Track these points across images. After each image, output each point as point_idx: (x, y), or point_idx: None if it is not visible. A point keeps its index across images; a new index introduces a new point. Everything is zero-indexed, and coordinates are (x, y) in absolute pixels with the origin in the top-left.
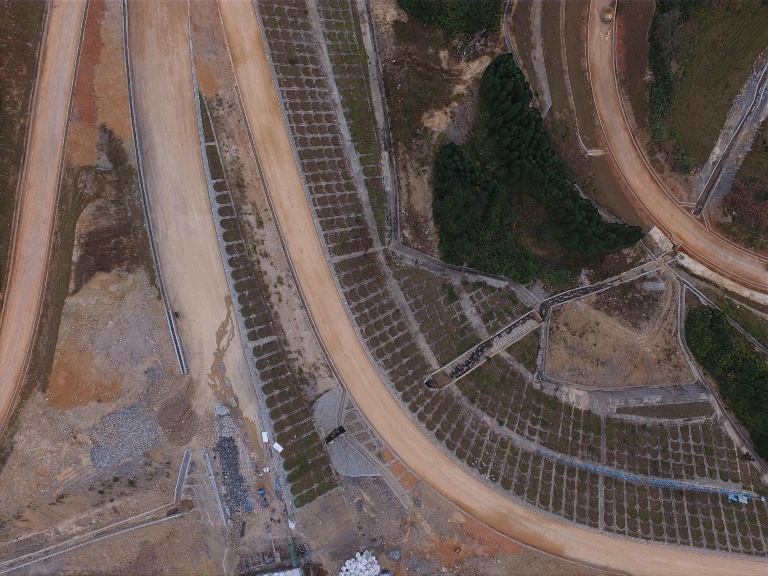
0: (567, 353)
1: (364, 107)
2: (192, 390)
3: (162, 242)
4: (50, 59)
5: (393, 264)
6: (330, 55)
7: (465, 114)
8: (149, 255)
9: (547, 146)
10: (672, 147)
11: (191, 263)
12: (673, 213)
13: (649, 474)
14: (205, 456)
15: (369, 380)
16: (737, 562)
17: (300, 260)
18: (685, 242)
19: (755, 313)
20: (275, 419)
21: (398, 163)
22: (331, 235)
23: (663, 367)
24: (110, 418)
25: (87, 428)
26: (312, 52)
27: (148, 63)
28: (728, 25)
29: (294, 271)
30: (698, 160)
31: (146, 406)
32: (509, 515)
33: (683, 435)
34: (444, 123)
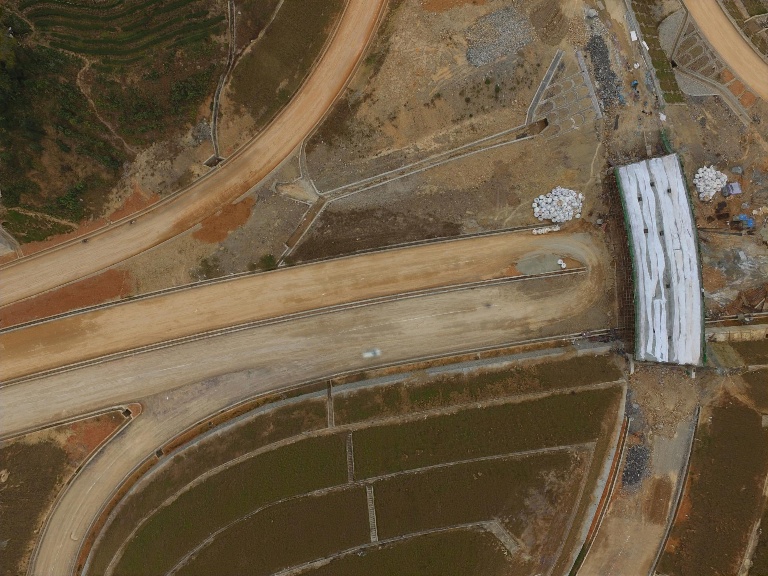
0: None
1: None
2: None
3: None
4: None
5: None
6: None
7: None
8: None
9: None
10: None
11: None
12: None
13: None
14: (577, 54)
15: (707, 6)
16: None
17: None
18: None
19: None
20: (639, 22)
21: None
22: None
23: None
24: (485, 18)
25: (462, 29)
26: None
27: None
28: None
29: None
30: None
31: (519, 8)
32: None
33: None
34: None
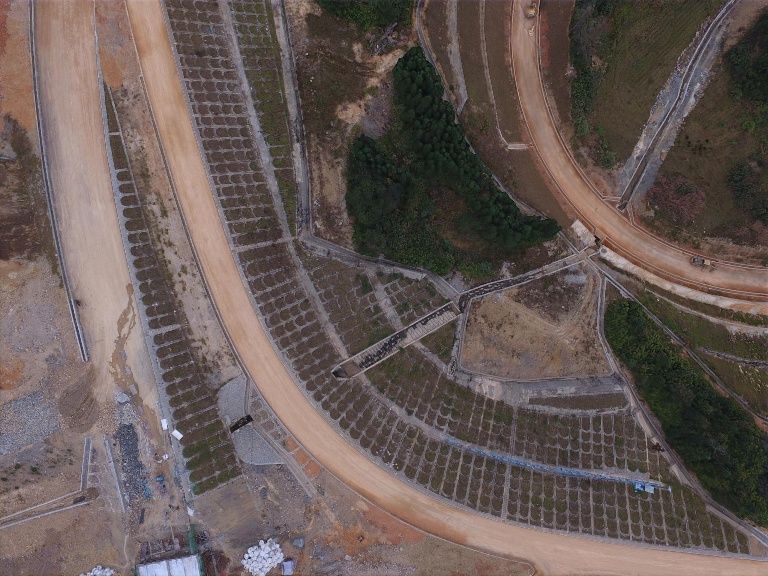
0: (482, 344)
1: (276, 99)
2: (93, 378)
3: (65, 231)
4: None
5: (303, 255)
6: (240, 47)
7: (380, 107)
8: (51, 243)
9: (459, 139)
10: (595, 142)
11: (93, 252)
12: (597, 207)
13: (557, 464)
14: (105, 443)
15: (273, 369)
16: (638, 551)
17: (205, 249)
18: (609, 236)
19: (675, 306)
20: (175, 407)
21: (311, 155)
22: (236, 225)
23: (580, 359)
24: (11, 405)
25: None
26: (222, 44)
27: (54, 54)
28: (651, 21)
29: (198, 260)
30: (621, 155)
31: (47, 393)
32: (412, 503)
33: (595, 426)
34: (358, 116)
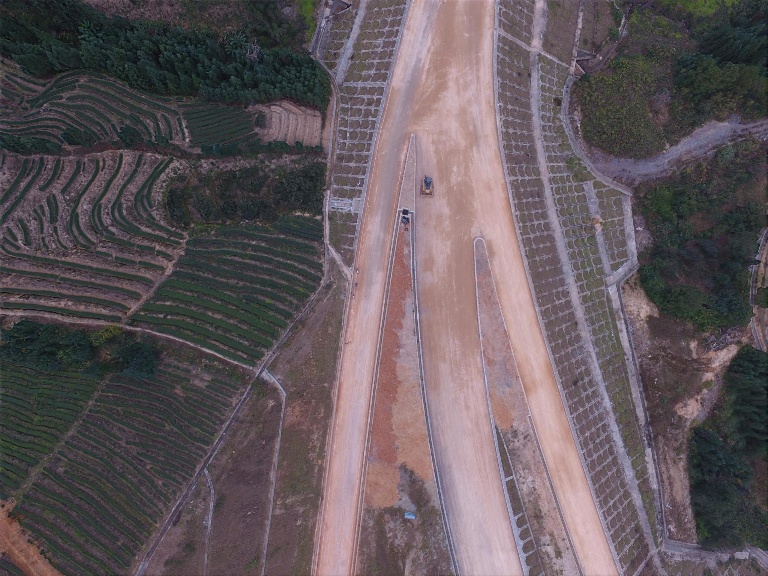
0: None
1: (628, 407)
2: None
3: None
4: (344, 396)
5: (666, 565)
6: (599, 363)
7: (711, 397)
8: None
9: None
10: None
11: None
12: None
13: None
14: None
15: None
16: None
17: None
18: None
19: None
20: None
21: (659, 457)
22: (623, 557)
23: None
24: None
25: None
26: (585, 364)
27: (444, 398)
28: None
29: None
30: None
31: None
32: None
33: None
34: (696, 410)
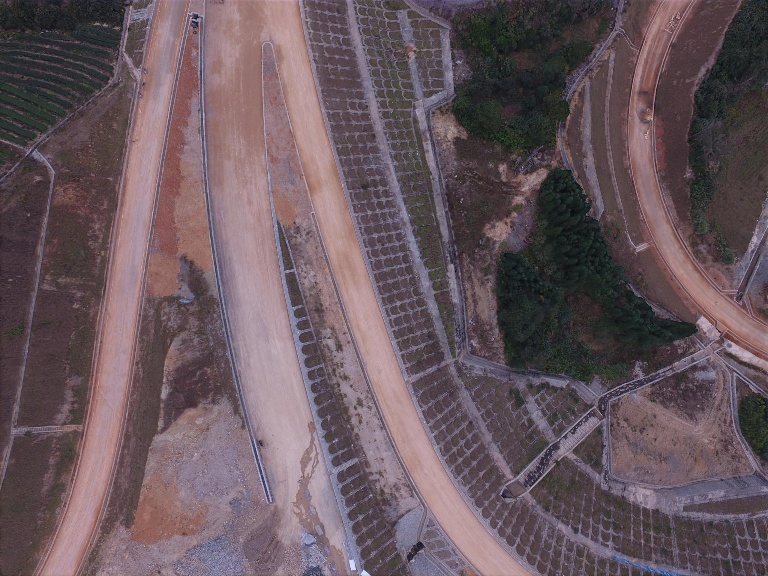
0: (631, 451)
1: (430, 222)
2: (277, 519)
3: (244, 370)
4: (130, 192)
5: (464, 375)
6: (397, 175)
7: (524, 223)
8: (232, 384)
9: (605, 253)
10: (714, 239)
11: (274, 390)
12: (717, 301)
13: (722, 575)
14: None
15: (449, 498)
16: None
17: (379, 381)
18: (730, 328)
19: None
20: (361, 545)
21: (463, 274)
22: (408, 355)
23: (722, 459)
24: (195, 551)
25: (172, 562)
26: (381, 174)
27: (227, 194)
28: (758, 122)
29: (373, 392)
30: (738, 250)
31: (232, 537)
32: None
33: (749, 531)
34: (505, 233)
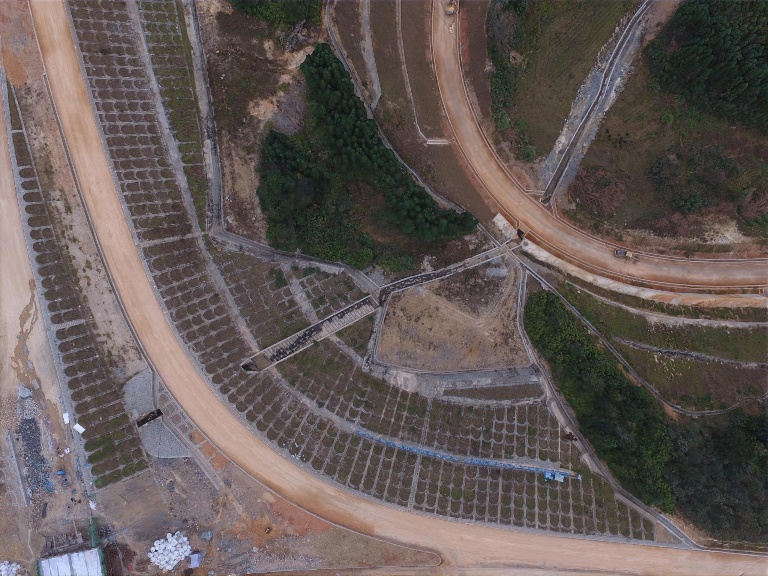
0: (399, 337)
1: (186, 96)
2: None
3: None
4: None
5: (214, 249)
6: (149, 46)
7: (293, 103)
8: None
9: (370, 134)
10: (515, 136)
11: None
12: (520, 201)
13: (468, 454)
14: (7, 438)
15: (179, 362)
16: (544, 539)
17: (109, 245)
18: (532, 229)
19: (595, 297)
20: (78, 401)
21: (222, 151)
22: (141, 220)
23: (499, 351)
24: None
25: None
26: (129, 42)
27: None
28: (571, 17)
29: (103, 256)
30: (543, 149)
31: None
32: (319, 495)
33: (509, 416)
34: (270, 112)
